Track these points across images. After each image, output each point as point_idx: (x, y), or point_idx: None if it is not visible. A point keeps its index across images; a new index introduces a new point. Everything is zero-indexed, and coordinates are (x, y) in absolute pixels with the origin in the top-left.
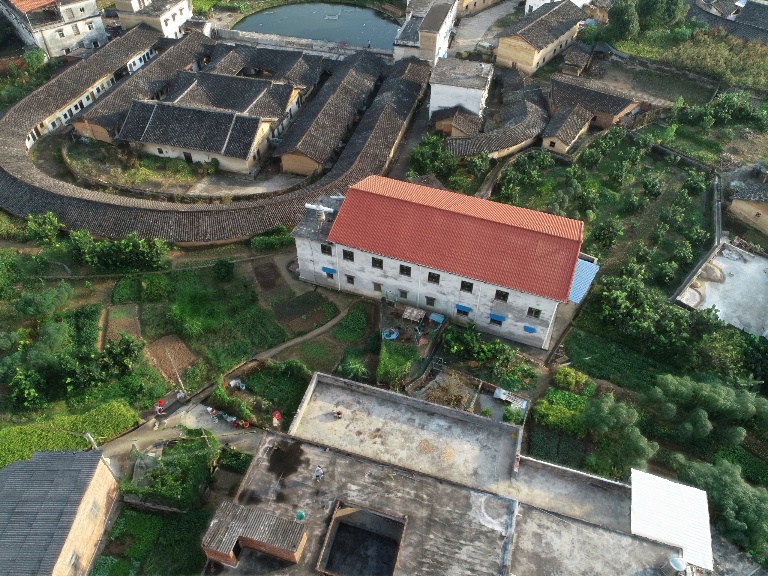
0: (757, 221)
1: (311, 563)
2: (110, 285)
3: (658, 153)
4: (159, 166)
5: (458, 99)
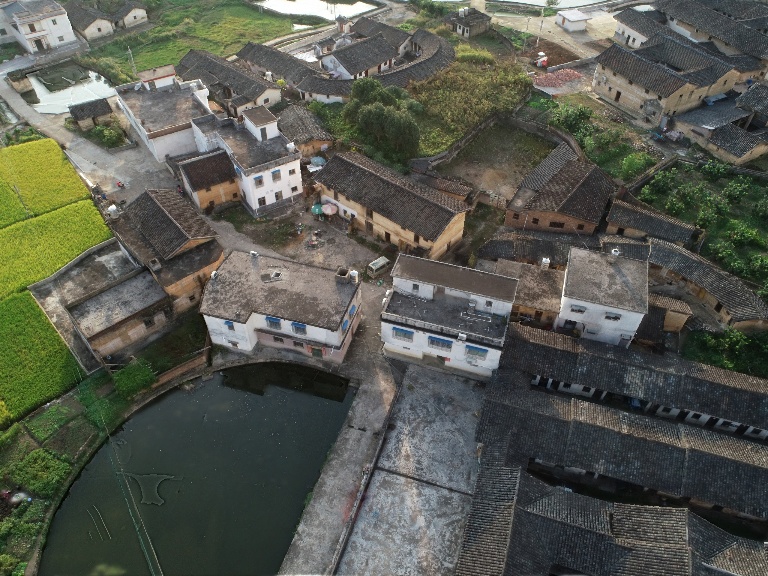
0: None
1: None
2: None
3: (651, 180)
4: None
5: None
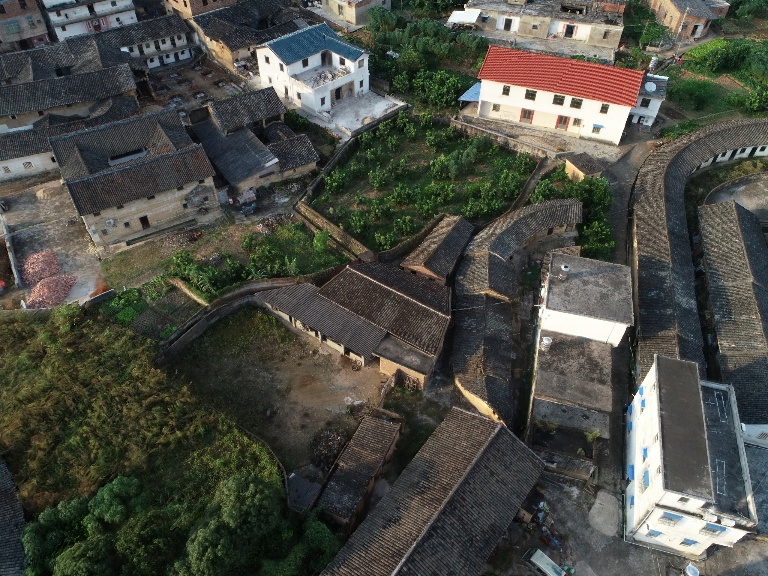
0: None
1: (588, 7)
2: None
3: None
4: None
5: None
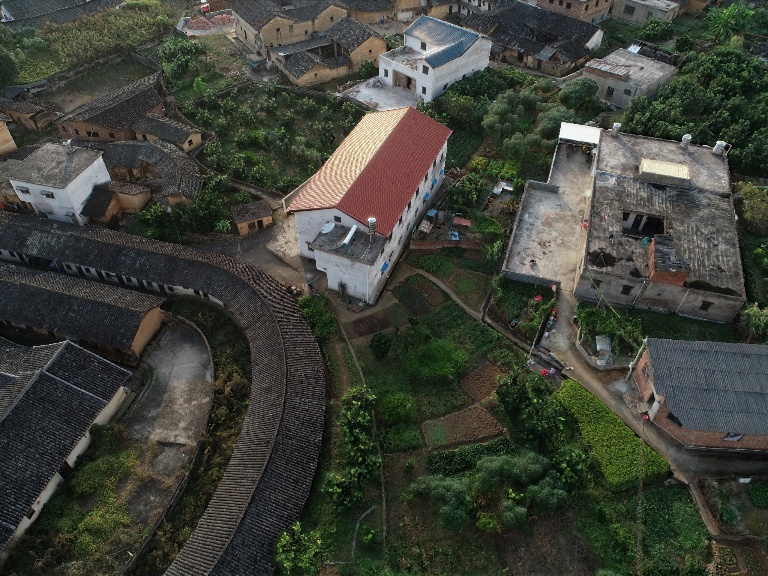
0: (318, 79)
1: None
2: (395, 456)
3: None
4: (79, 505)
5: (90, 181)
